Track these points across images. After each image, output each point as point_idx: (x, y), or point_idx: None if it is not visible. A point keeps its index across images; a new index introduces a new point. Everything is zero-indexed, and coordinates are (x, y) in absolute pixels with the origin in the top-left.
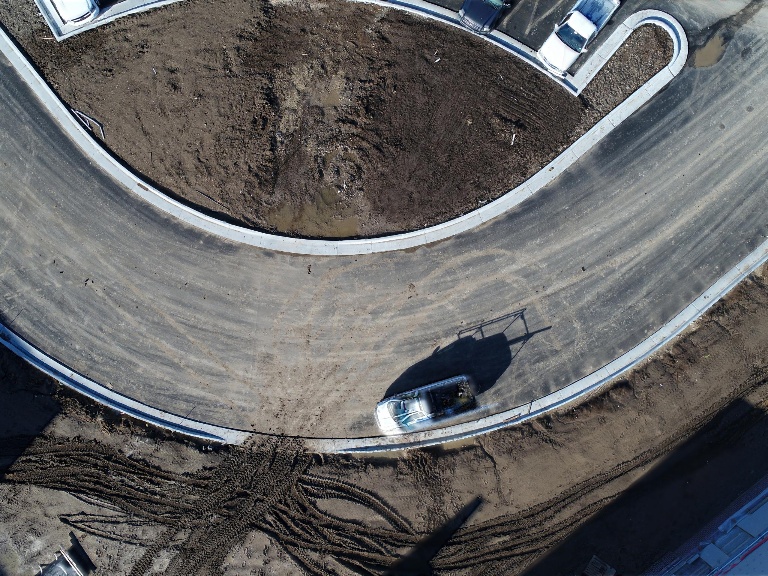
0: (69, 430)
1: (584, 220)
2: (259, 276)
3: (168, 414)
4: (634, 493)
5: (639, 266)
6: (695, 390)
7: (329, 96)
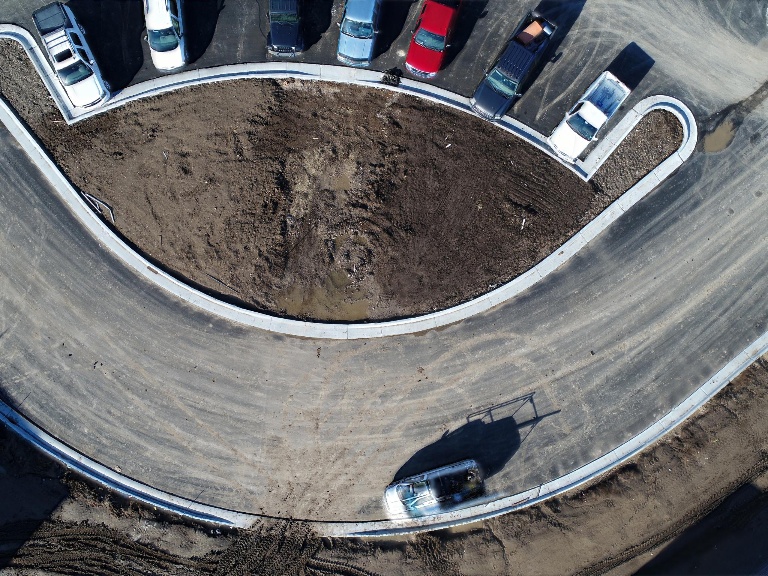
0: (77, 514)
1: (593, 304)
2: (268, 359)
3: (177, 497)
4: None
5: (648, 350)
6: (703, 475)
7: (339, 180)
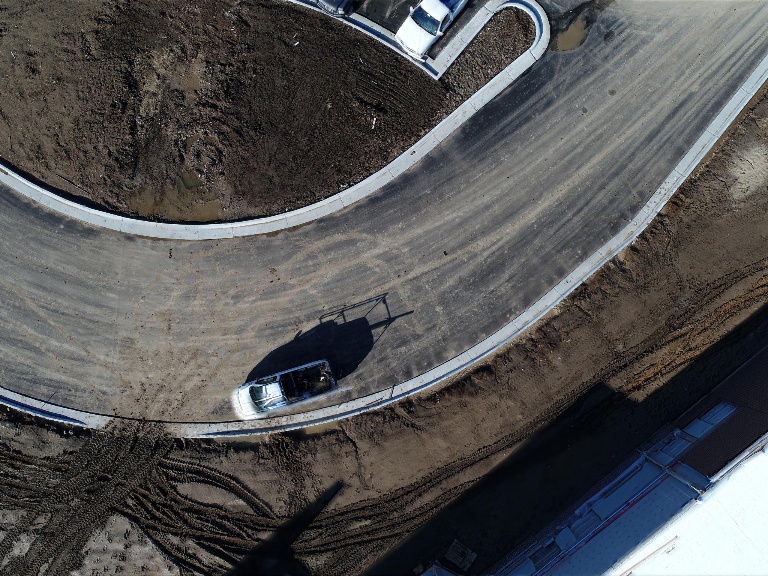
0: None
1: (446, 204)
2: (120, 260)
3: (29, 398)
4: (495, 477)
5: (501, 250)
6: (556, 374)
7: (189, 80)
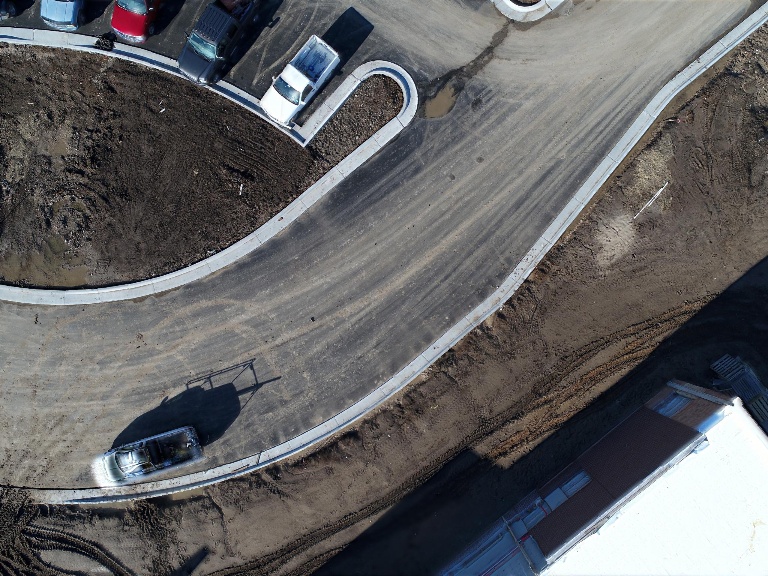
0: None
1: (314, 270)
2: None
3: None
4: (361, 545)
5: (369, 316)
6: (423, 441)
7: (56, 145)
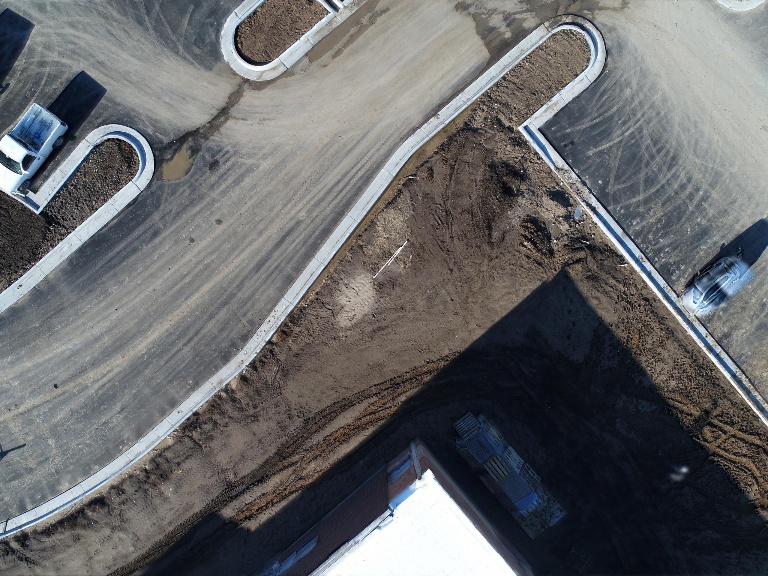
0: None
1: (55, 337)
2: None
3: None
4: None
5: (112, 382)
6: (168, 506)
7: None
